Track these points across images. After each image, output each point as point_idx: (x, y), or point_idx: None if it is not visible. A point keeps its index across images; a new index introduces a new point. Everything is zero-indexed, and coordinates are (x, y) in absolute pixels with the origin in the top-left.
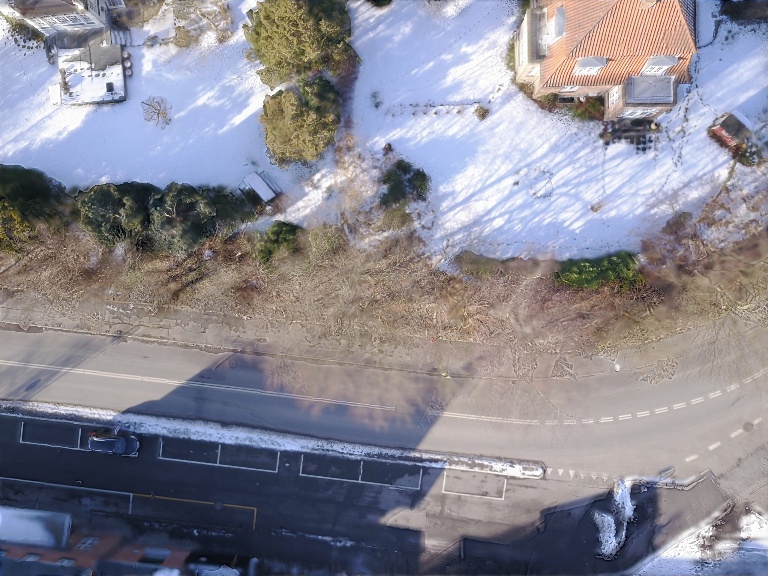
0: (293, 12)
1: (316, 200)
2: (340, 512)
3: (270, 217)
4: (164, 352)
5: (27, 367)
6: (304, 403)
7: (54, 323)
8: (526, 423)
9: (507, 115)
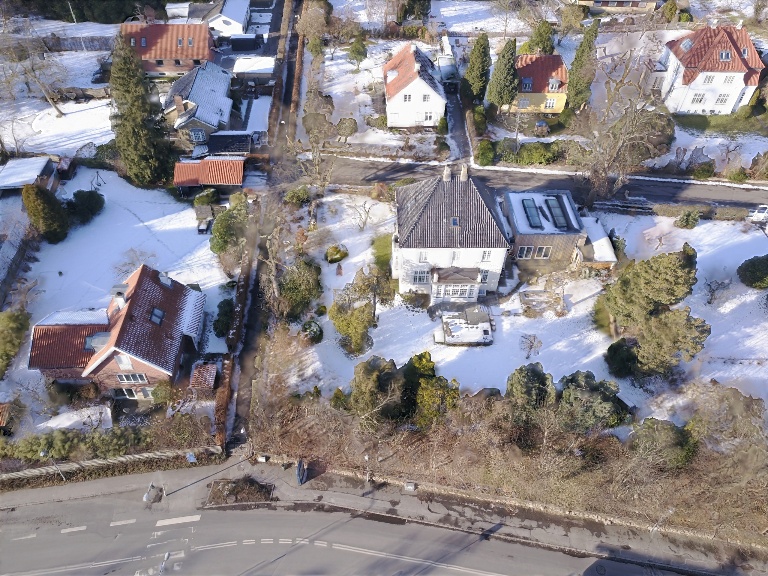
0: (675, 263)
1: (663, 416)
2: None
3: (627, 426)
4: (528, 552)
5: (388, 558)
6: None
7: (417, 516)
8: None
9: None
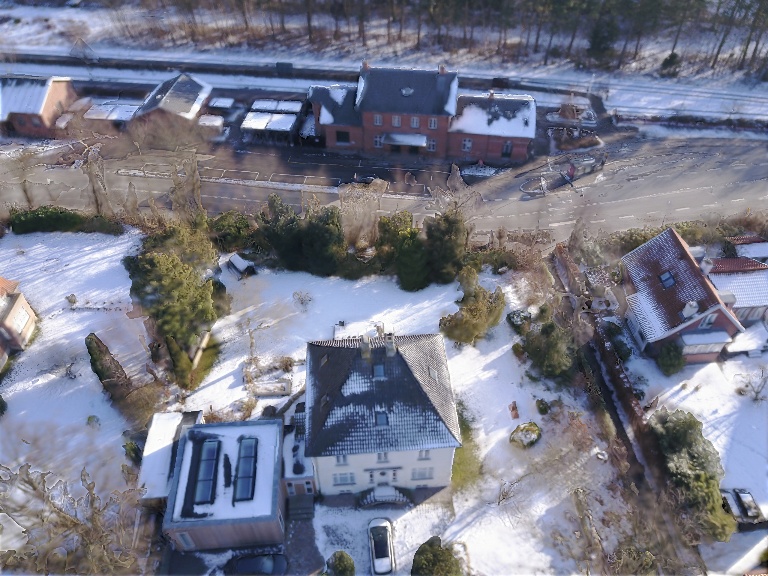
0: None
1: None
2: (240, 161)
3: None
4: None
5: (422, 214)
6: (249, 198)
7: None
8: (119, 189)
9: (54, 300)
